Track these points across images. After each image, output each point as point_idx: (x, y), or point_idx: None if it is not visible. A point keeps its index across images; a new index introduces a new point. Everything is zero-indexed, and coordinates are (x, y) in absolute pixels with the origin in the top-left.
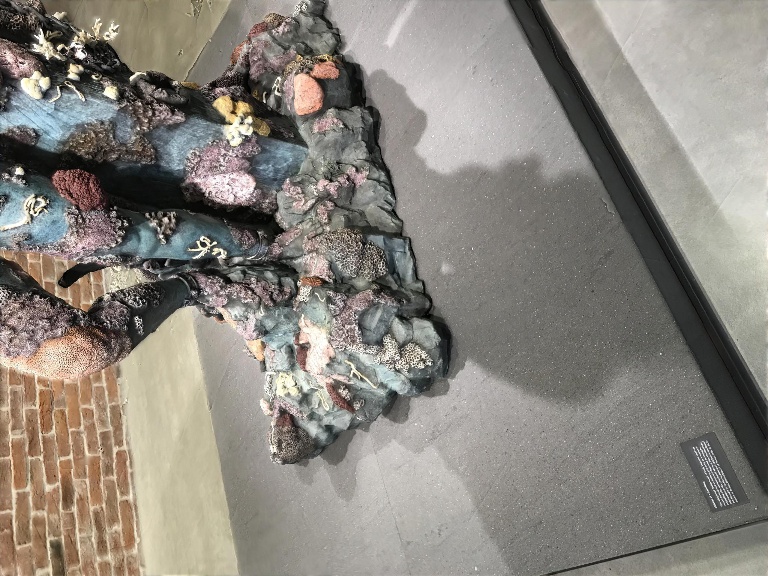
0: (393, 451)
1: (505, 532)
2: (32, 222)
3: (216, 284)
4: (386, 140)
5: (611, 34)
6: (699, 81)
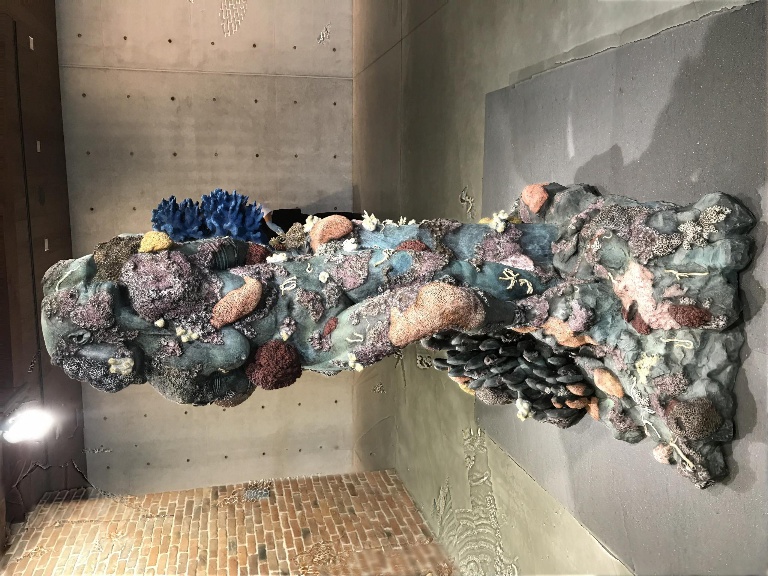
0: None
1: None
2: (390, 258)
3: (533, 297)
4: (606, 189)
5: (683, 7)
6: None
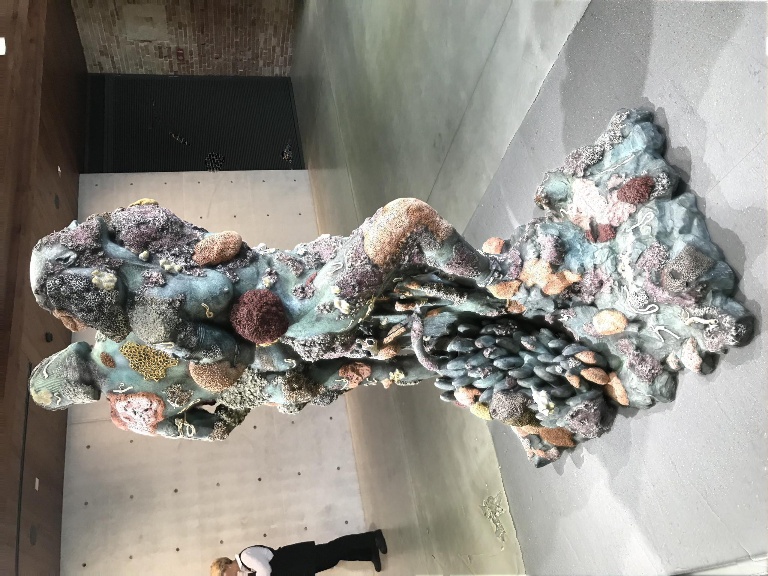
0: (711, 157)
1: (736, 5)
2: None
3: None
4: None
5: None
6: None
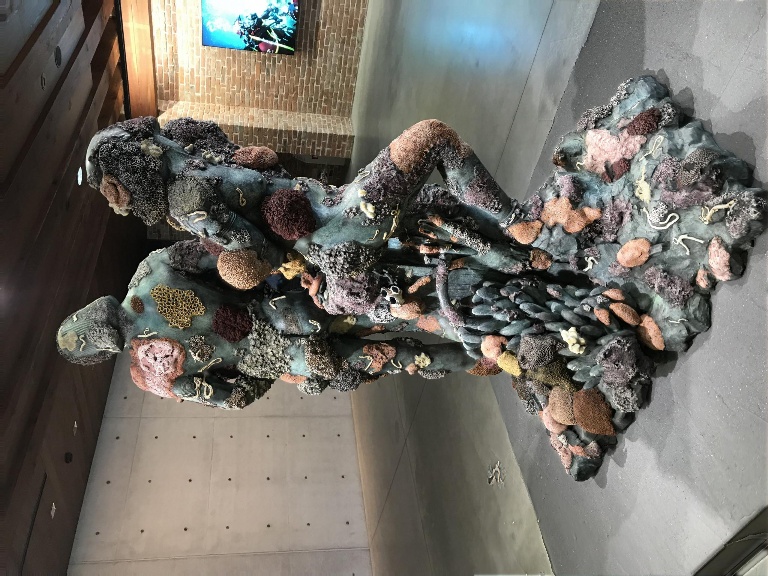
0: (709, 82)
1: None
2: None
3: None
4: None
5: None
6: None
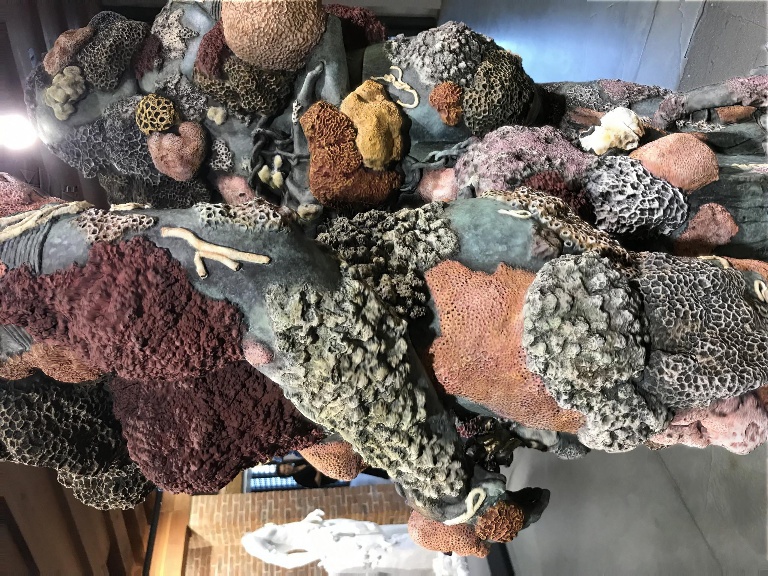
0: (767, 62)
1: None
2: None
3: None
4: None
5: None
6: None
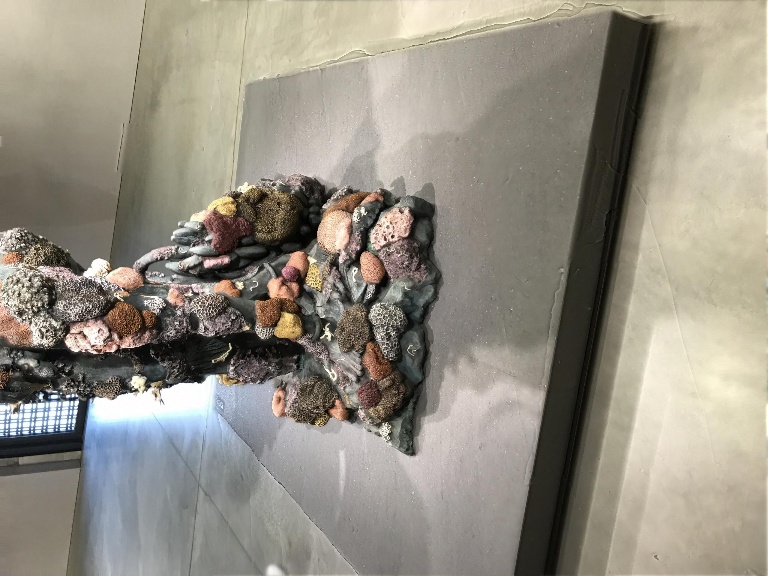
0: None
1: None
2: None
3: None
4: None
5: None
6: (295, 507)
